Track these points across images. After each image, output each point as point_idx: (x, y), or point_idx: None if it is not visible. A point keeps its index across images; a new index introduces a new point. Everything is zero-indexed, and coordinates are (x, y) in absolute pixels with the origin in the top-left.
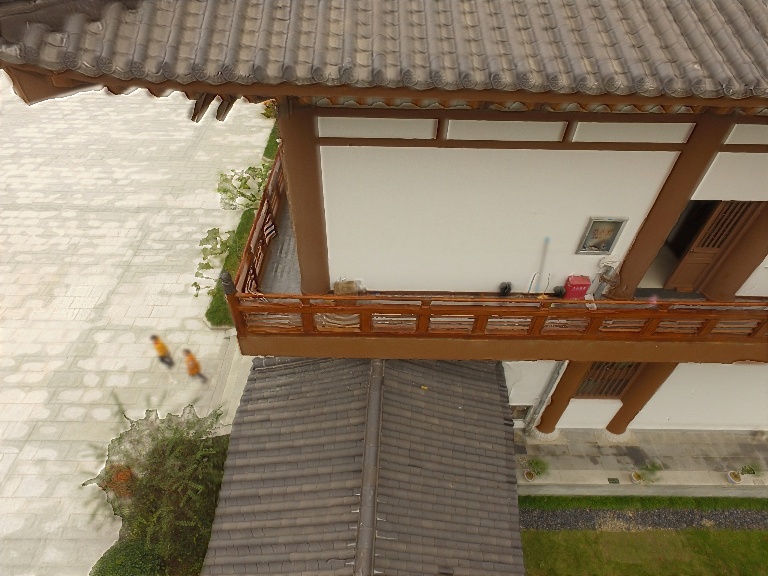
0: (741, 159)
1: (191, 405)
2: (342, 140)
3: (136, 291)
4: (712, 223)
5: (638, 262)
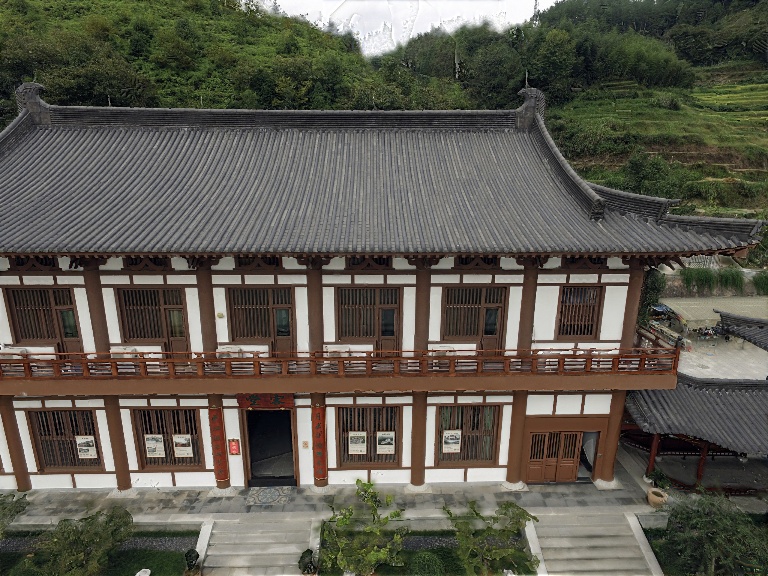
0: None
1: (671, 518)
2: None
3: None
4: None
5: None
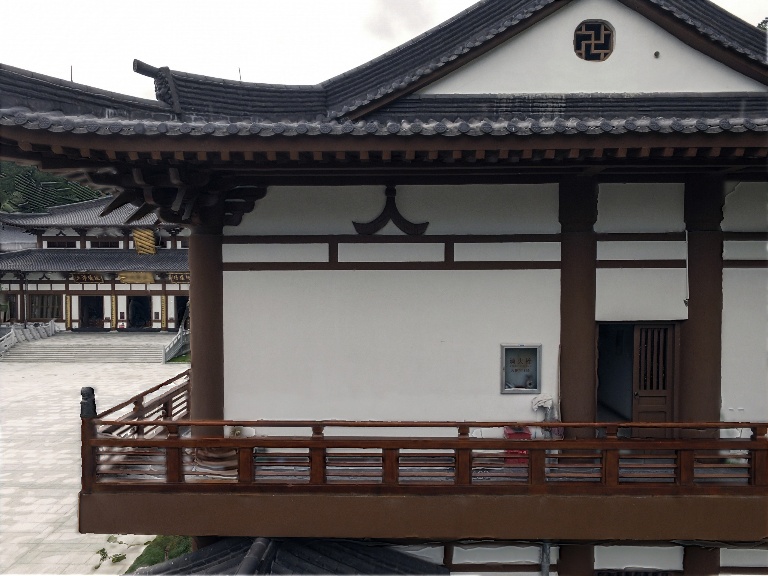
0: (621, 274)
1: None
2: (243, 265)
3: (29, 574)
4: (639, 356)
5: (575, 401)
